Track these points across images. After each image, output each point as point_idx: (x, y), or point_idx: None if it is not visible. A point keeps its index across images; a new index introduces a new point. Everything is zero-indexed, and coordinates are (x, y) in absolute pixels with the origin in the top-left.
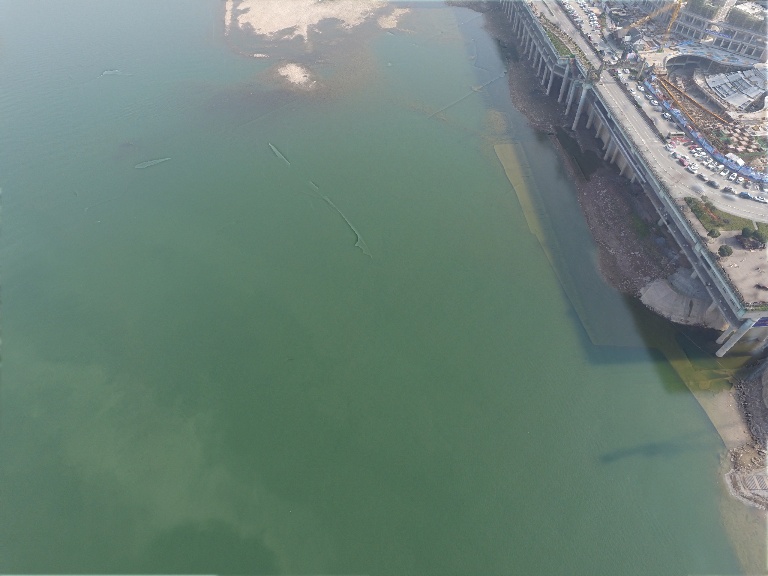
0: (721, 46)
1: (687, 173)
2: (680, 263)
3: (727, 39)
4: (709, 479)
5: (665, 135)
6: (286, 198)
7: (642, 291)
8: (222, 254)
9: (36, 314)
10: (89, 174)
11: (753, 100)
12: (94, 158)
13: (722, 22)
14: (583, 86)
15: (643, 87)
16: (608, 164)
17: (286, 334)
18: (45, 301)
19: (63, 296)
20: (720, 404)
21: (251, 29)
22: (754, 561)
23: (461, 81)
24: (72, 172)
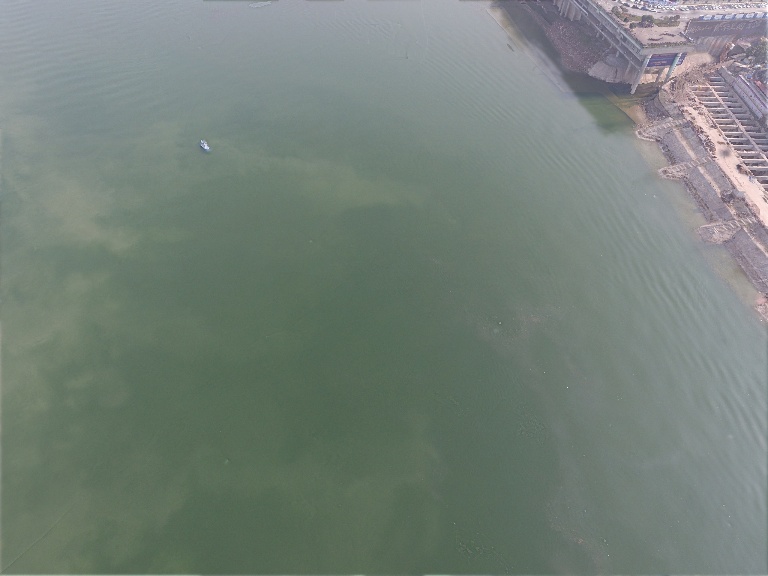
0: None
1: (612, 1)
2: (610, 52)
3: None
4: (628, 134)
5: None
6: (348, 39)
7: (589, 70)
8: (317, 64)
9: (210, 85)
10: (195, 26)
11: None
12: (194, 16)
13: None
14: None
15: None
16: (563, 17)
17: (377, 97)
18: (212, 81)
19: (221, 80)
20: (633, 110)
21: None
22: (649, 156)
23: None
24: (184, 23)
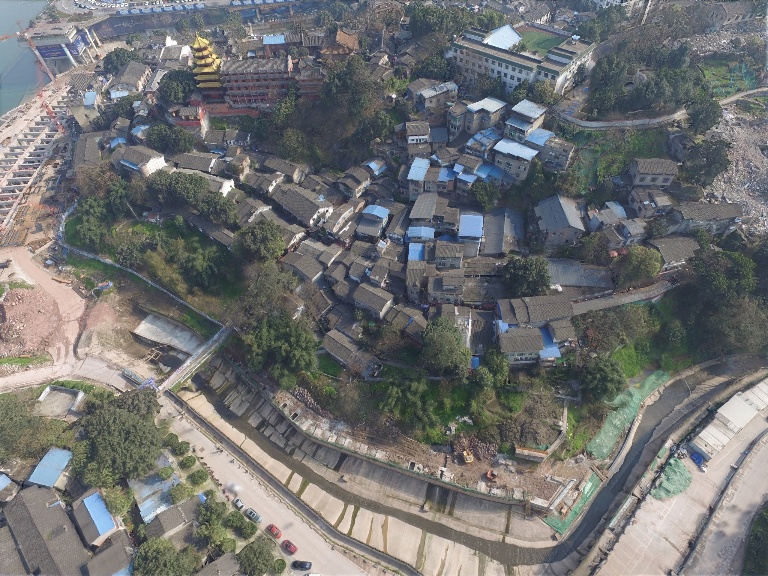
0: None
1: None
2: None
3: None
4: None
5: None
6: None
7: None
8: None
9: None
10: None
11: None
12: None
13: None
14: None
15: None
16: None
17: None
18: None
19: None
20: (32, 96)
21: None
22: None
23: None
24: None
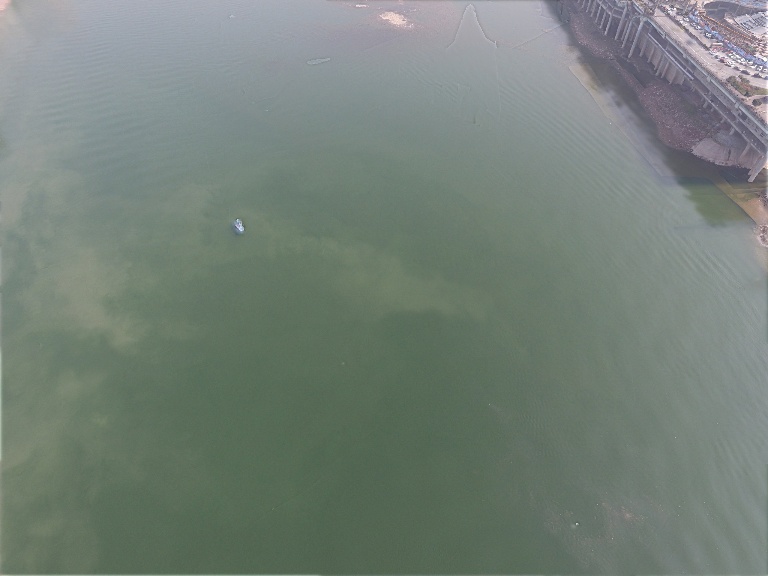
0: None
1: (726, 67)
2: (721, 128)
3: None
4: (746, 239)
5: (708, 46)
6: (410, 98)
7: (693, 148)
8: (374, 127)
9: (255, 152)
10: (251, 79)
11: None
12: (252, 69)
13: None
14: (641, 19)
15: (688, 19)
16: (659, 78)
17: (437, 171)
18: (258, 146)
19: (268, 145)
20: (752, 204)
21: None
22: None
23: (533, 26)
24: (240, 76)
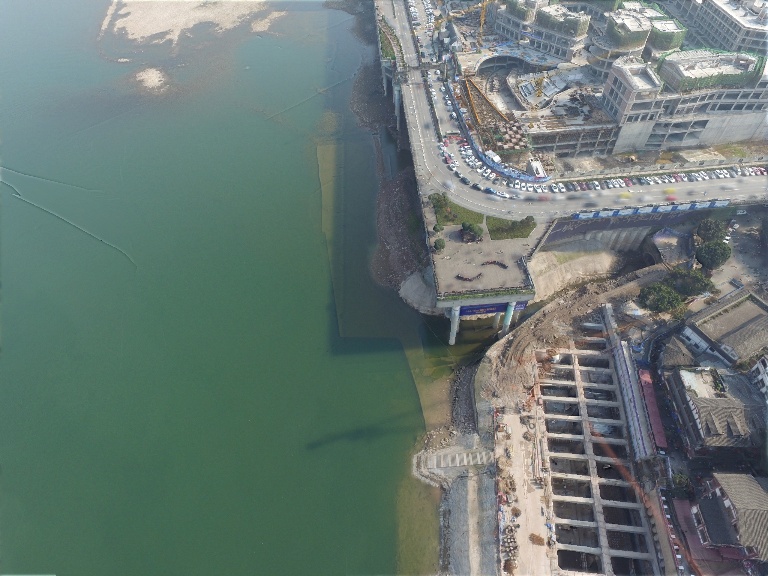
0: (535, 47)
1: (447, 170)
2: None
3: (538, 40)
4: (399, 460)
5: (444, 134)
6: None
7: (402, 284)
8: (19, 259)
9: None
10: None
11: (548, 99)
12: None
13: (533, 24)
14: (394, 87)
15: (445, 88)
16: None
17: (55, 336)
18: None
19: None
20: (435, 389)
21: (124, 34)
22: (411, 535)
23: (310, 83)
24: None
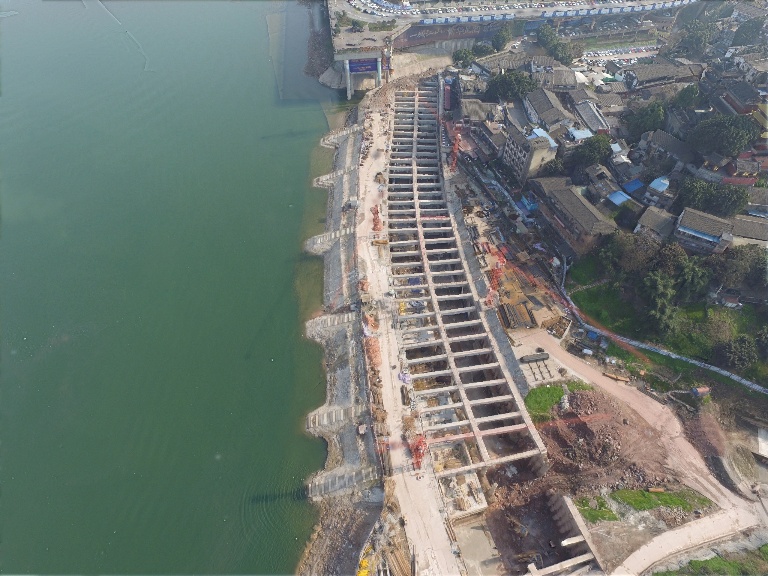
0: None
1: (349, 5)
2: None
3: None
4: (313, 141)
5: None
6: None
7: None
8: (57, 73)
9: None
10: None
11: None
12: None
13: None
14: None
15: None
16: None
17: (92, 106)
18: None
19: None
20: (337, 116)
21: None
22: (317, 164)
23: None
24: None
